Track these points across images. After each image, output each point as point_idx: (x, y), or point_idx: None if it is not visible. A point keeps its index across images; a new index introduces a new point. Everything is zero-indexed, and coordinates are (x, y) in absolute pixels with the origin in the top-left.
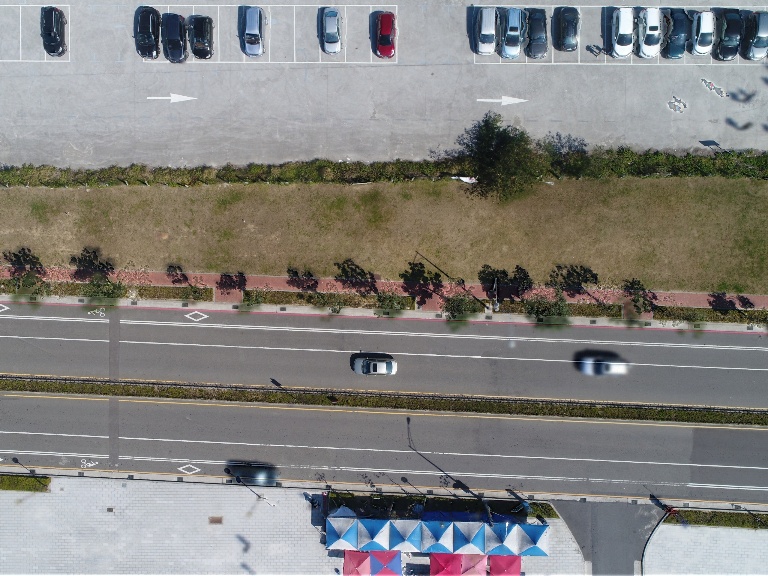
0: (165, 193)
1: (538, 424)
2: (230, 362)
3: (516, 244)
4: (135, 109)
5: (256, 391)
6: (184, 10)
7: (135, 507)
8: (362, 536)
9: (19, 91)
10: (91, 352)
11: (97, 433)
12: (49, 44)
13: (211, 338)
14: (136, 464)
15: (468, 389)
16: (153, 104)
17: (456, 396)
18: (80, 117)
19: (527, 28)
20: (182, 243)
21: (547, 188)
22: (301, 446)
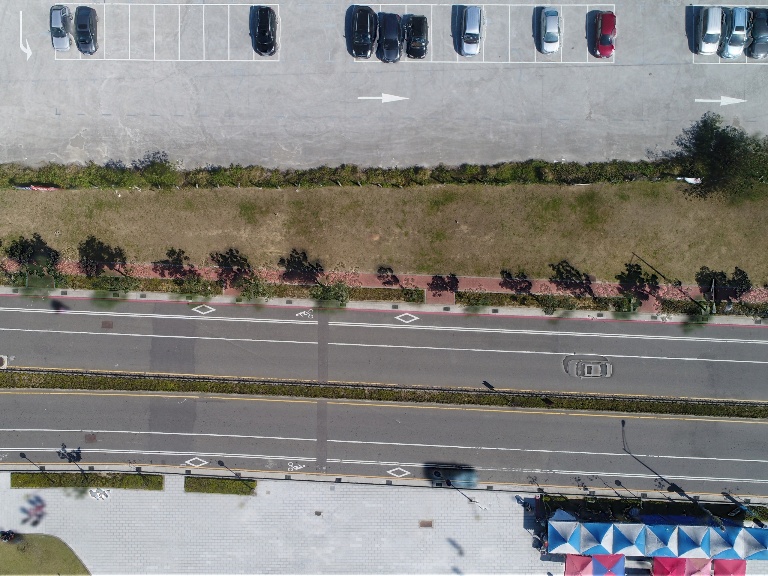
0: (377, 194)
1: (755, 427)
2: (441, 364)
3: (735, 245)
4: (345, 109)
5: (469, 393)
6: (396, 9)
7: (343, 510)
8: (586, 540)
9: (227, 91)
10: (299, 354)
11: (305, 436)
12: (262, 43)
13: (422, 340)
14: (344, 467)
15: (684, 391)
16: (364, 104)
17: (672, 399)
18: (289, 117)
19: (751, 28)
20: (394, 244)
21: (767, 189)
22: (513, 449)
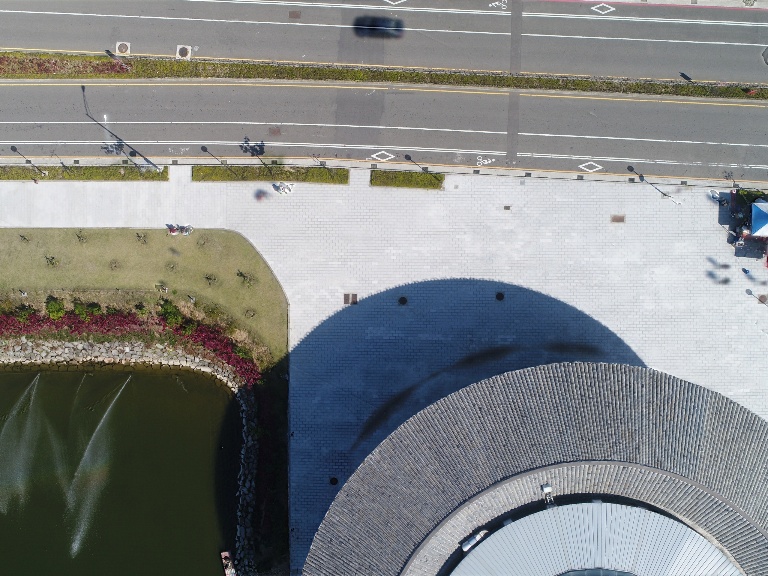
0: None
1: None
2: (638, 55)
3: None
4: None
5: (666, 84)
6: None
7: (533, 205)
8: None
9: None
10: (491, 45)
11: (495, 129)
12: None
13: (618, 31)
14: (535, 161)
15: None
16: None
17: None
18: None
19: None
20: None
21: None
22: (710, 142)
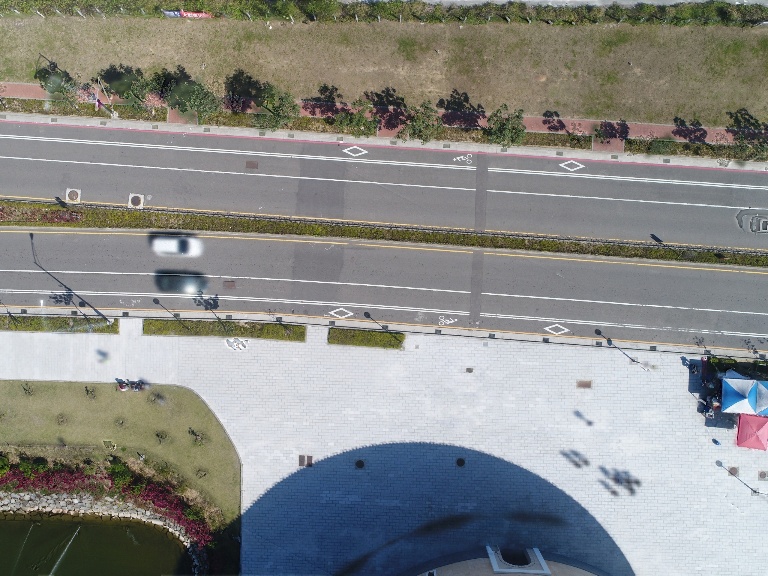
0: (545, 32)
1: None
2: (607, 215)
3: None
4: None
5: (636, 246)
6: None
7: (497, 368)
8: (764, 398)
9: None
10: (455, 201)
11: (458, 288)
12: None
13: (587, 189)
14: (499, 322)
15: None
16: None
17: None
18: None
19: None
20: (561, 86)
21: None
22: (680, 307)
